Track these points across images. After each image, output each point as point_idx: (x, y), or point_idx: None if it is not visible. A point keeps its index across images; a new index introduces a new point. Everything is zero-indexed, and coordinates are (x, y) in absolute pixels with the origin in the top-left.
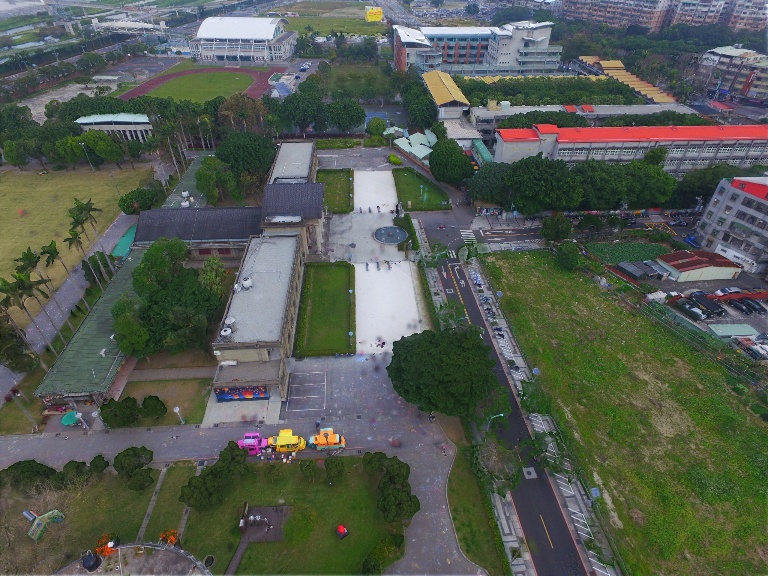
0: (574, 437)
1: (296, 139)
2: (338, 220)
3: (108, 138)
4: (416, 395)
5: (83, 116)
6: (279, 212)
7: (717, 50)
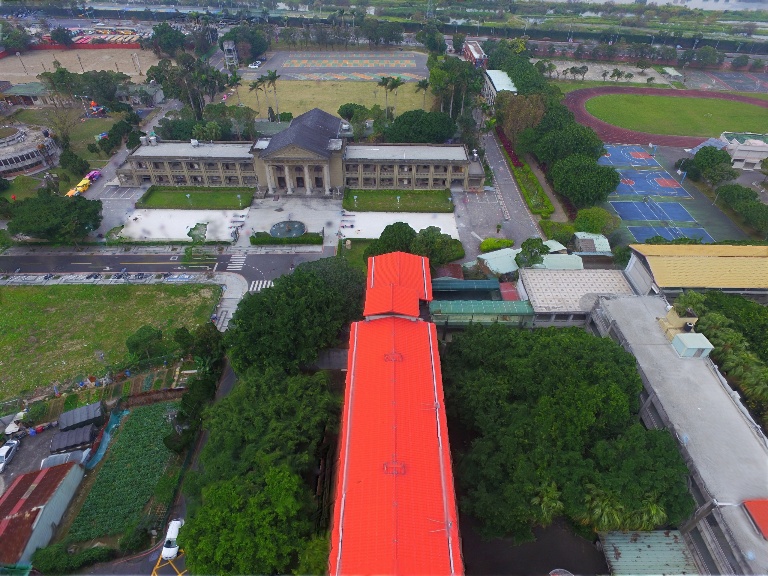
0: None
1: (544, 175)
2: (331, 203)
3: (438, 79)
4: None
5: (501, 70)
6: None
7: None
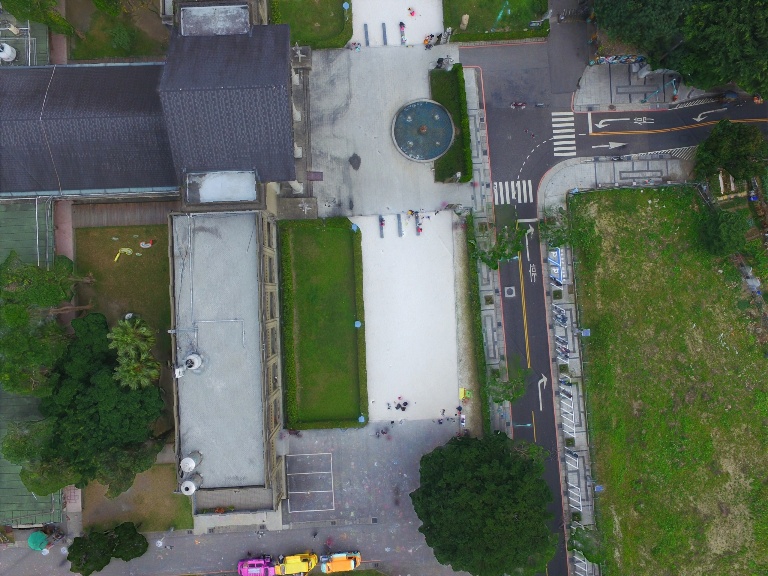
0: (613, 557)
1: None
2: (323, 73)
3: None
4: (446, 560)
5: None
6: (209, 167)
7: None
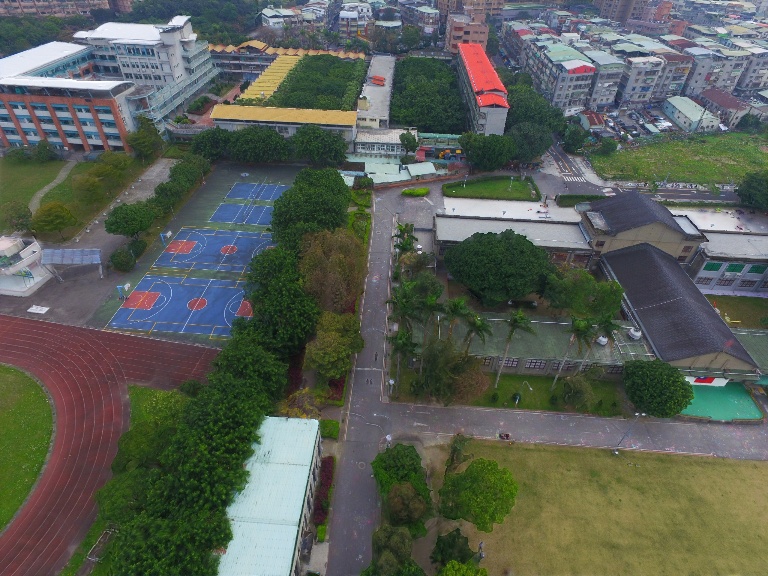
0: None
1: None
2: None
3: None
4: None
5: None
6: None
7: (275, 13)
